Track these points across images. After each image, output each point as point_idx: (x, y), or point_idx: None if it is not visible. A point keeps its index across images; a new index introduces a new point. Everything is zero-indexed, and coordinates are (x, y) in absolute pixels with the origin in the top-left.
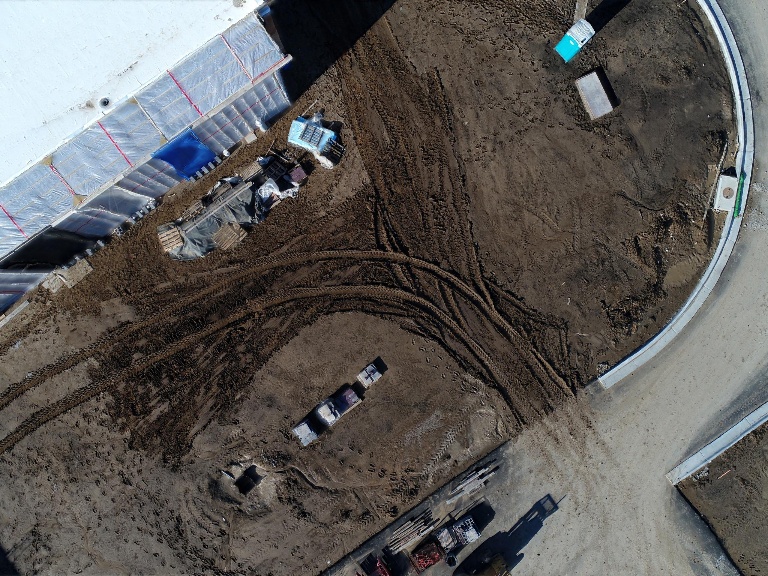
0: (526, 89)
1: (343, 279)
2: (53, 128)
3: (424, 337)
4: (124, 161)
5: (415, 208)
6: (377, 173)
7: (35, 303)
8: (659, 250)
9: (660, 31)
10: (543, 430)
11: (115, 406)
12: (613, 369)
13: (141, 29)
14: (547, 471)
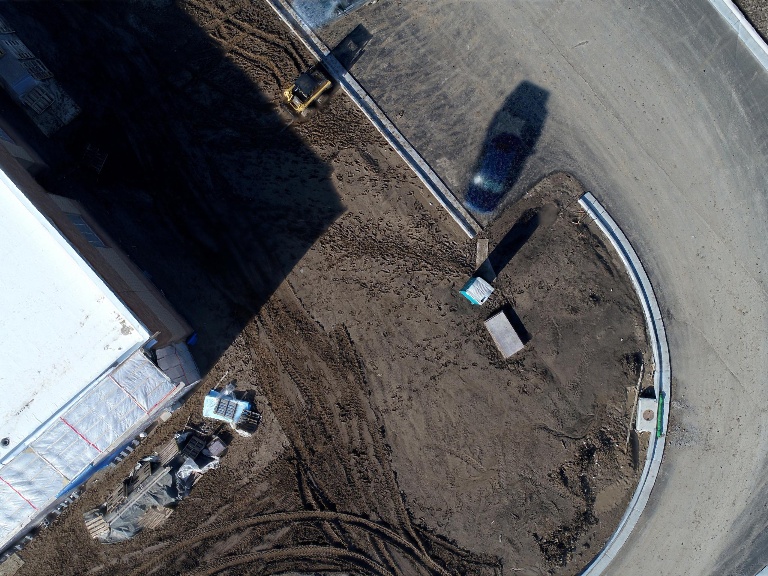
0: (436, 334)
1: (274, 542)
2: None
3: None
4: (29, 507)
5: (338, 464)
6: (296, 435)
7: None
8: (586, 478)
9: (564, 262)
10: None
11: None
12: None
13: (33, 367)
14: None
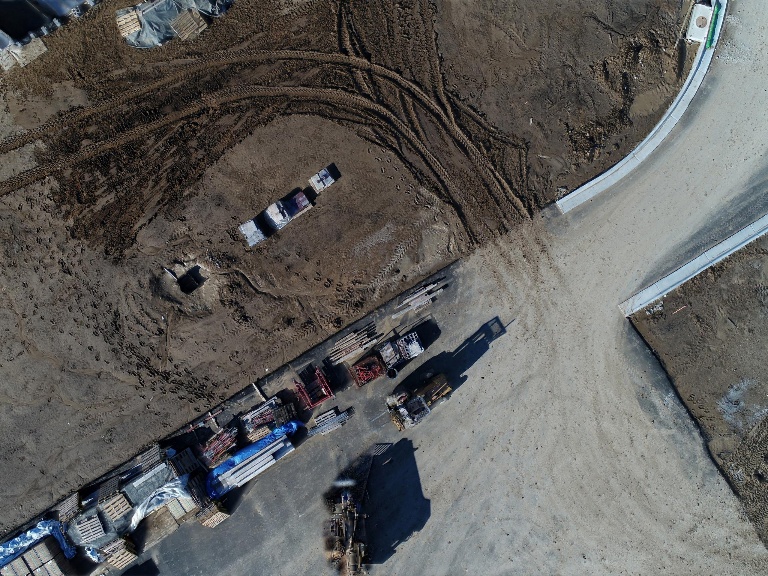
0: None
1: (302, 81)
2: None
3: (381, 146)
4: None
5: (380, 14)
6: None
7: None
8: (627, 76)
9: None
10: (496, 251)
11: (60, 192)
12: (572, 193)
13: None
14: (497, 293)
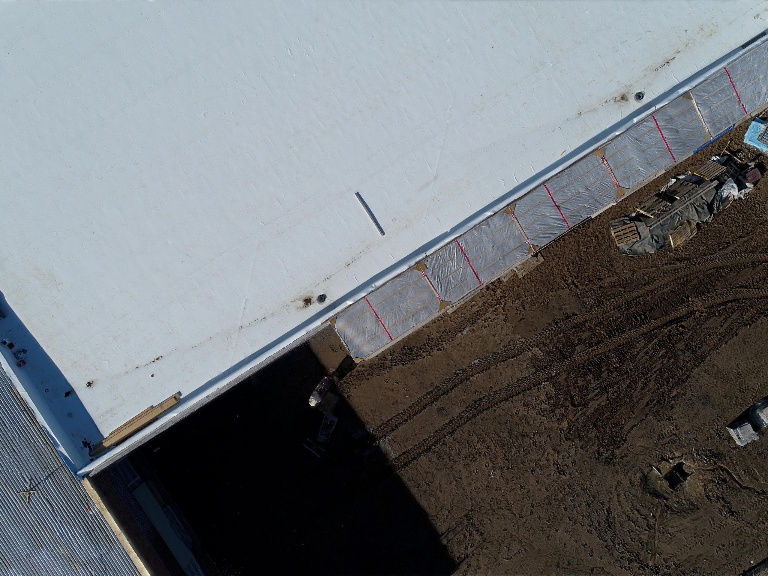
0: None
1: None
2: (588, 120)
3: None
4: (669, 156)
5: None
6: None
7: (486, 291)
8: None
9: None
10: None
11: (555, 397)
12: None
13: (681, 25)
14: None
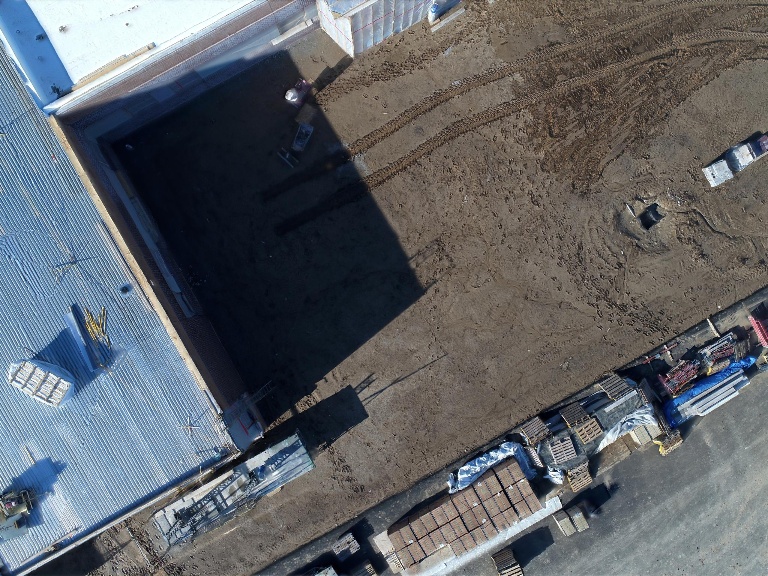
0: None
1: None
2: None
3: None
4: None
5: None
6: None
7: (470, 11)
8: None
9: None
10: None
11: (533, 125)
12: None
13: None
14: None
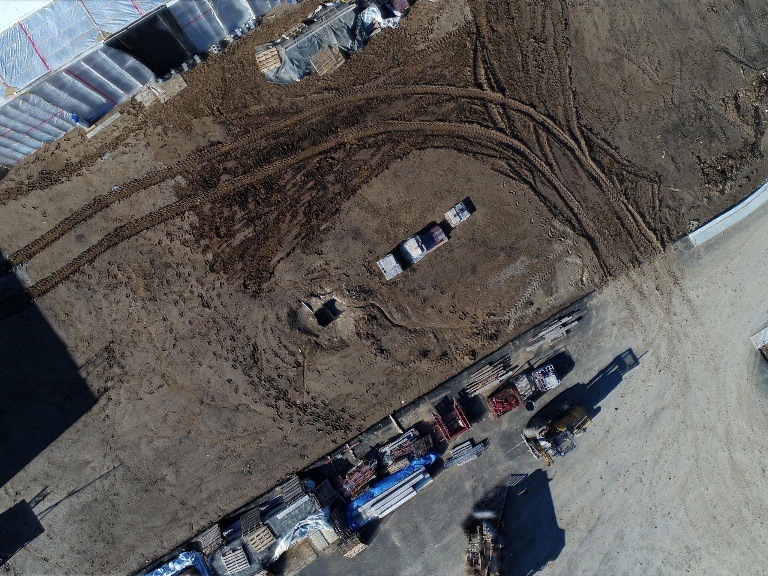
0: None
1: (437, 115)
2: None
3: (515, 180)
4: None
5: (515, 48)
6: (479, 10)
7: (127, 115)
8: (758, 109)
9: None
10: (629, 283)
11: (199, 227)
12: (704, 226)
13: None
14: (630, 325)
